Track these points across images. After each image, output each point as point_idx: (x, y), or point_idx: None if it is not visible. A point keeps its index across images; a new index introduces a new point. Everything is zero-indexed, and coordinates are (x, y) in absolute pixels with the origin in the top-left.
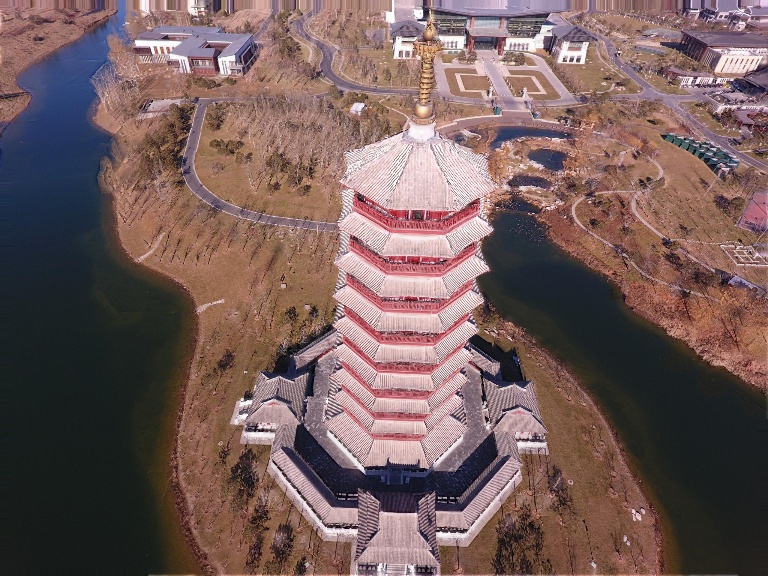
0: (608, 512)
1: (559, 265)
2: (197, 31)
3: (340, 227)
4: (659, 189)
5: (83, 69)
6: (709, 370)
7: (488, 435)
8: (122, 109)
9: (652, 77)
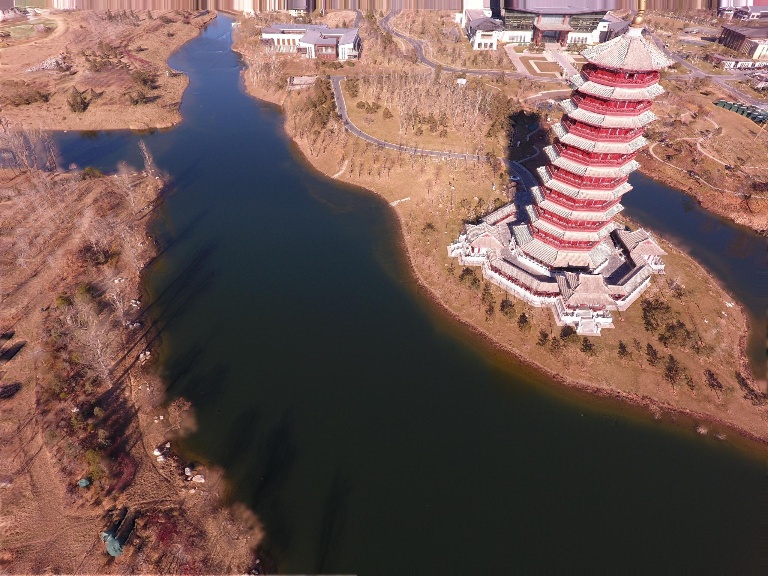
0: (710, 301)
1: (645, 185)
2: (308, 27)
3: (580, 90)
4: (717, 137)
5: (216, 58)
6: (767, 243)
7: (624, 262)
8: (269, 84)
9: (698, 63)
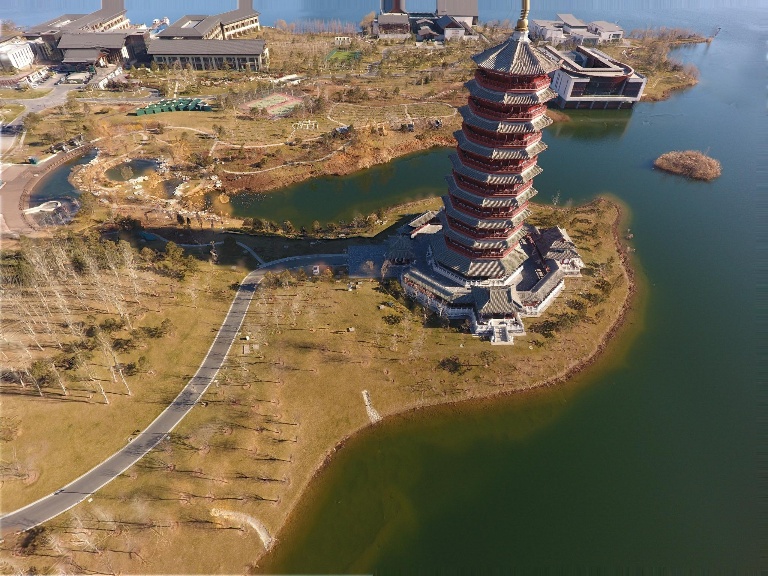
0: None
1: (294, 195)
2: None
3: None
4: None
5: None
6: None
7: None
8: None
9: None
